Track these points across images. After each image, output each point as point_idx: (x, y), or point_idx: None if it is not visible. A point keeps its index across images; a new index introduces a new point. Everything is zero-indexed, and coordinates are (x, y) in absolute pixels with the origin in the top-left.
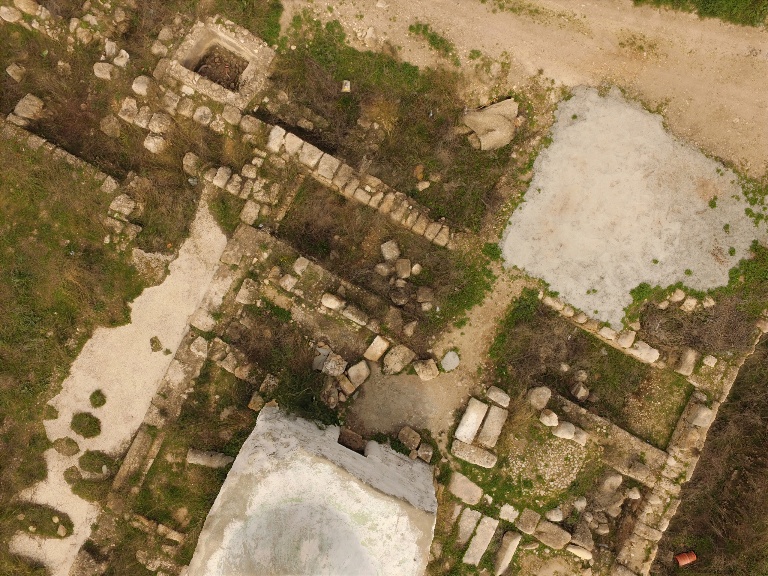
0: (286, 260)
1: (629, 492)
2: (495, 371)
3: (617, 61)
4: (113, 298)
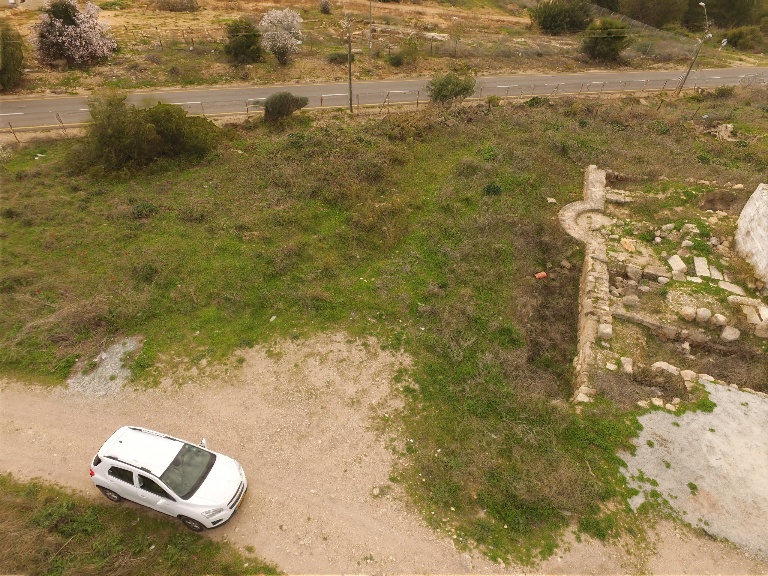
0: None
1: None
2: None
3: None
4: None
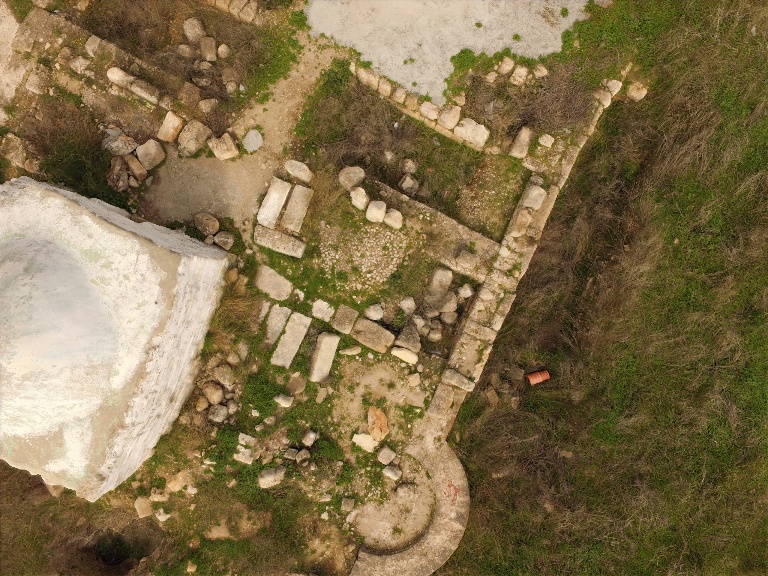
0: (79, 42)
1: (460, 290)
2: (302, 150)
3: None
4: None
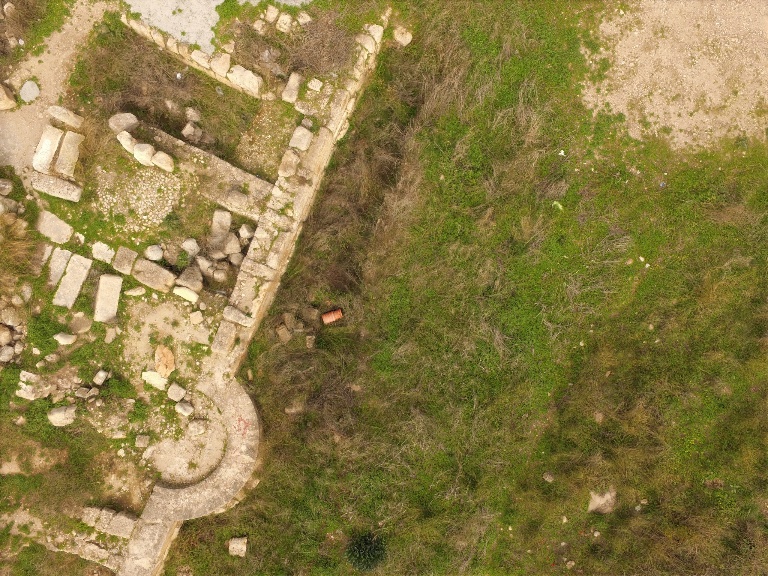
0: None
1: None
2: (77, 99)
3: None
4: None
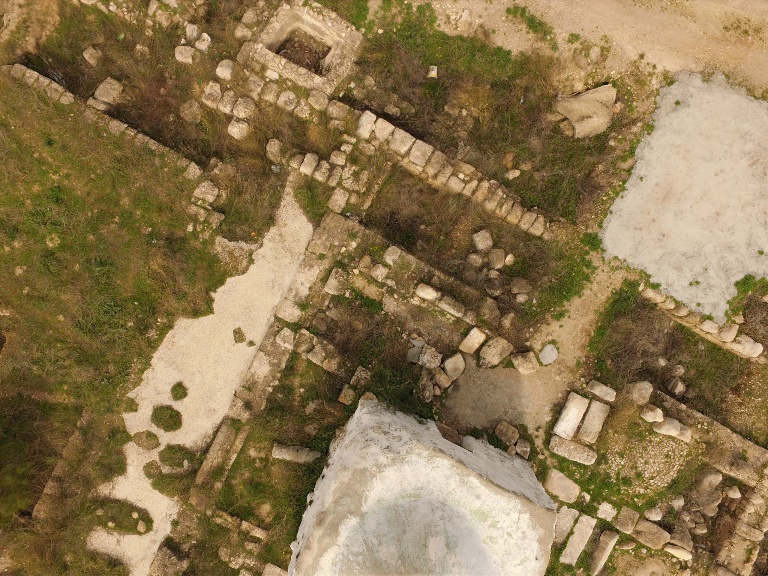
0: (376, 249)
1: (729, 491)
2: (595, 365)
3: (721, 46)
4: (195, 288)
